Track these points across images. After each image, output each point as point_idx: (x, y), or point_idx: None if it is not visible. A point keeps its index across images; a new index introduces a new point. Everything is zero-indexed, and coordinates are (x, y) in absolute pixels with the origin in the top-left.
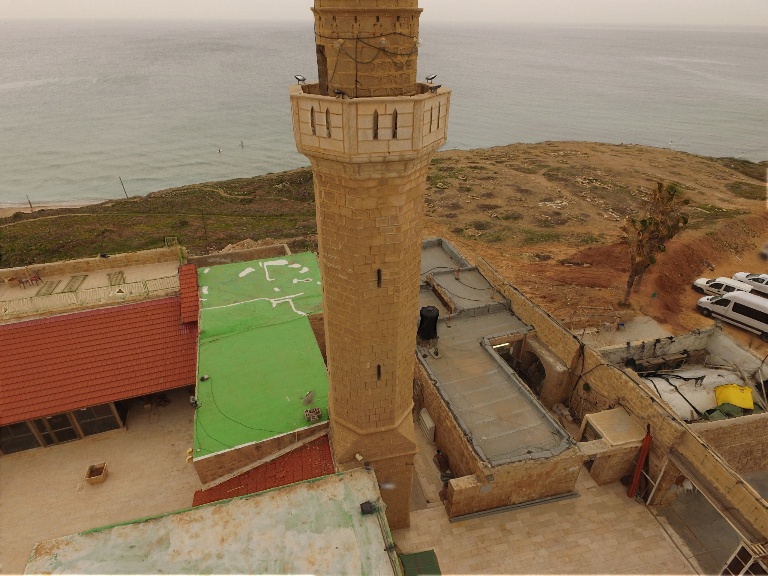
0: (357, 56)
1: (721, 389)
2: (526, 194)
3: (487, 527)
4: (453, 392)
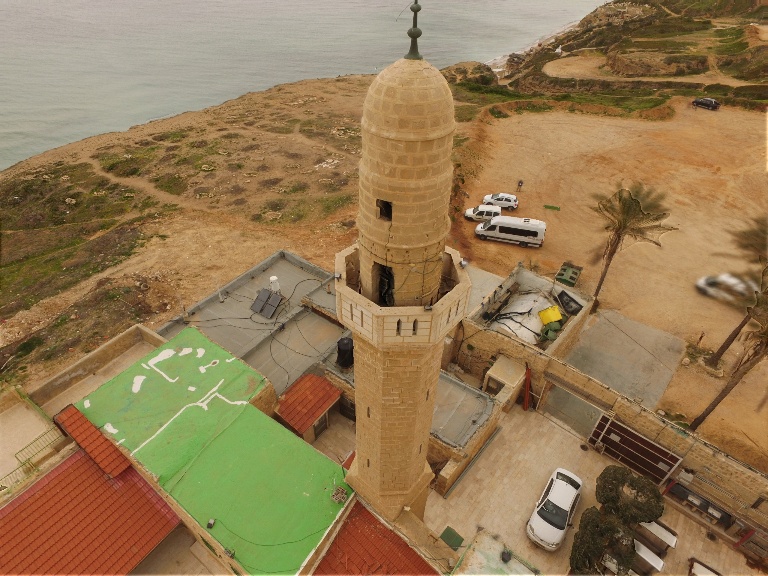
0: (424, 271)
1: (543, 313)
2: (297, 159)
3: (468, 486)
4: None
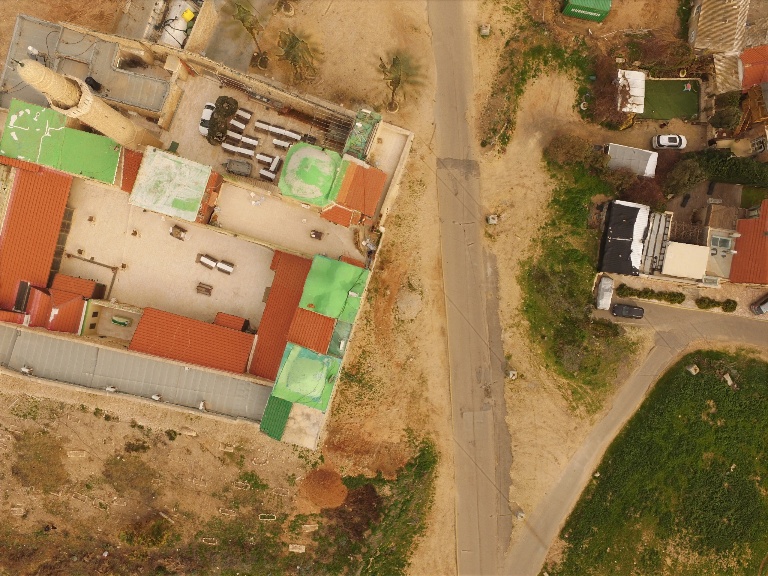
0: None
1: None
2: None
3: (176, 123)
4: (129, 99)
